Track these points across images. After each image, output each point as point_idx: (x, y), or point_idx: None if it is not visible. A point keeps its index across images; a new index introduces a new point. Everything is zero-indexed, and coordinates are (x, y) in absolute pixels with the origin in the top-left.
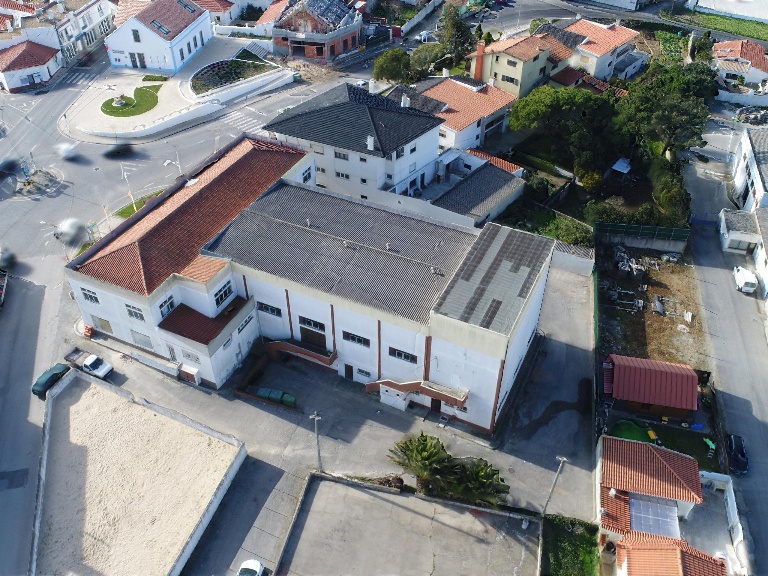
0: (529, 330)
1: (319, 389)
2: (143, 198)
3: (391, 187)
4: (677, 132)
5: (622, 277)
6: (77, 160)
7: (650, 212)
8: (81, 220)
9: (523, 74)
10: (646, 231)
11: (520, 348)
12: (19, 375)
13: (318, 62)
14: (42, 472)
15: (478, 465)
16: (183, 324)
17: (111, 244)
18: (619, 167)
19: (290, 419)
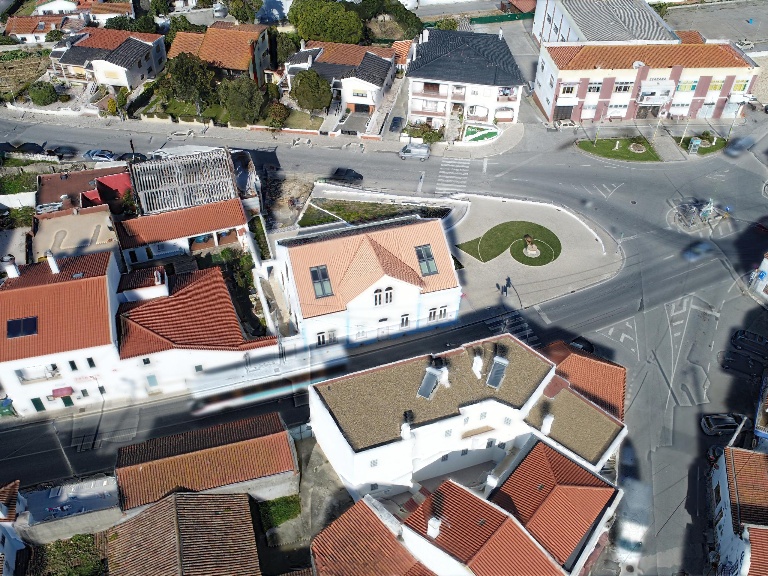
0: None
1: None
2: (641, 138)
3: None
4: None
5: None
6: (642, 221)
7: None
8: (689, 171)
9: None
10: None
11: None
12: None
13: None
14: None
15: None
16: None
17: (724, 66)
18: None
19: None
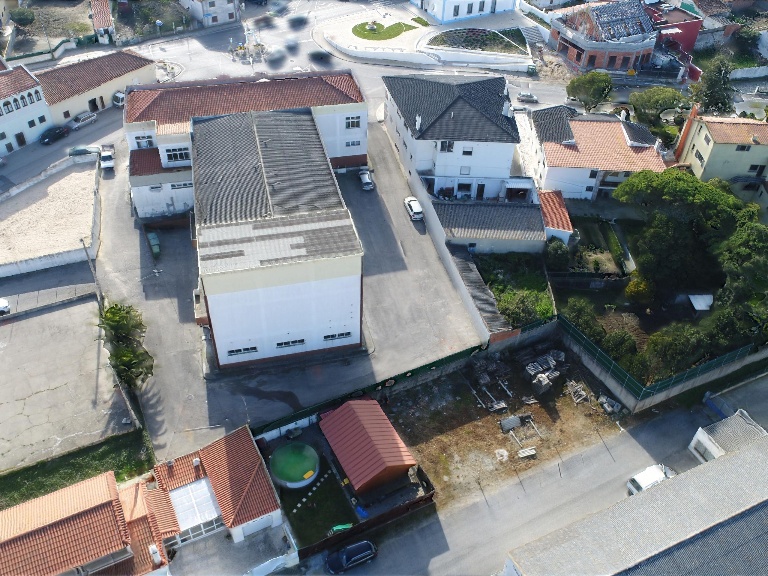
0: (317, 321)
1: (186, 261)
2: None
3: (430, 175)
4: (765, 292)
5: (525, 377)
6: (292, 50)
7: (620, 342)
8: None
9: (713, 157)
10: (603, 358)
11: (283, 322)
12: (82, 142)
13: (573, 66)
14: (14, 189)
15: (134, 354)
16: (145, 159)
17: None
18: (698, 300)
19: (143, 261)
